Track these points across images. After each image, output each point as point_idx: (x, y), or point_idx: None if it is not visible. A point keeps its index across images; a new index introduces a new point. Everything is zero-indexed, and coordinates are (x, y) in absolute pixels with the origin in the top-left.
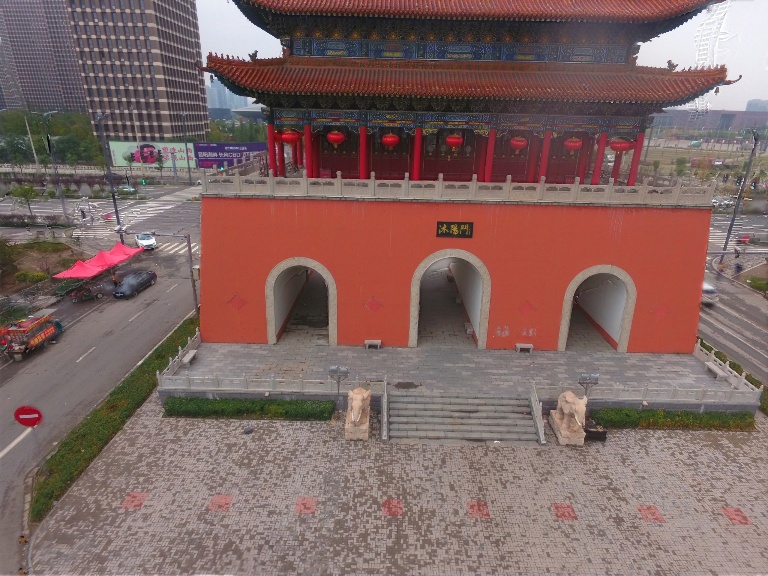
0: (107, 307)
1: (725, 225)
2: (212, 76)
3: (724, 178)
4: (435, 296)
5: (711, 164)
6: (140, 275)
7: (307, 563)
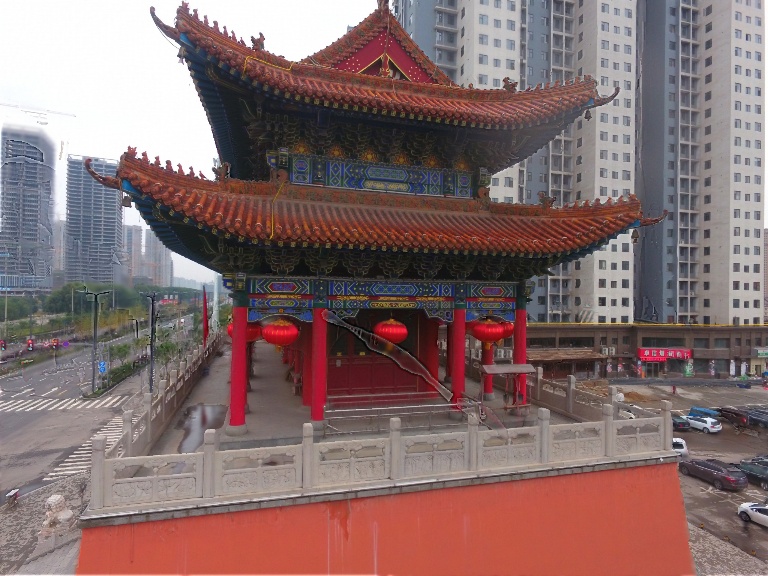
0: None
1: (5, 395)
2: (635, 233)
3: None
4: None
5: None
6: None
7: (753, 569)
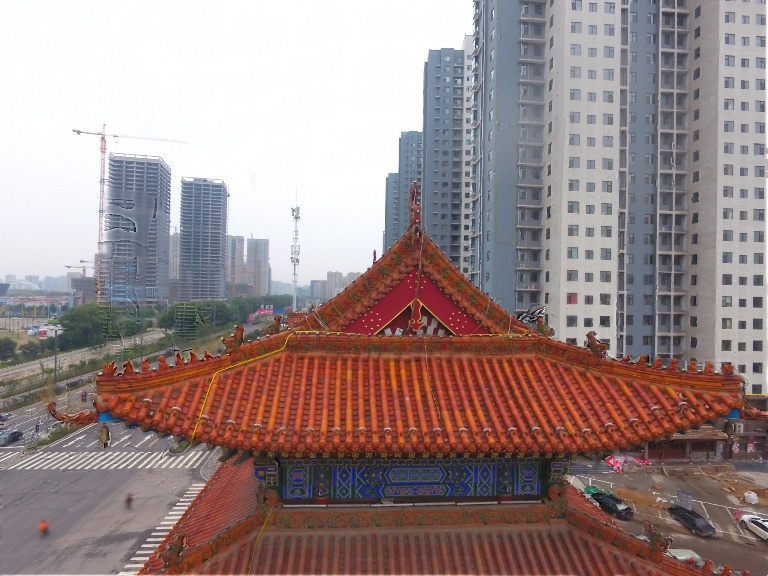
0: None
1: None
2: None
3: (83, 397)
4: None
5: (56, 385)
6: None
7: None
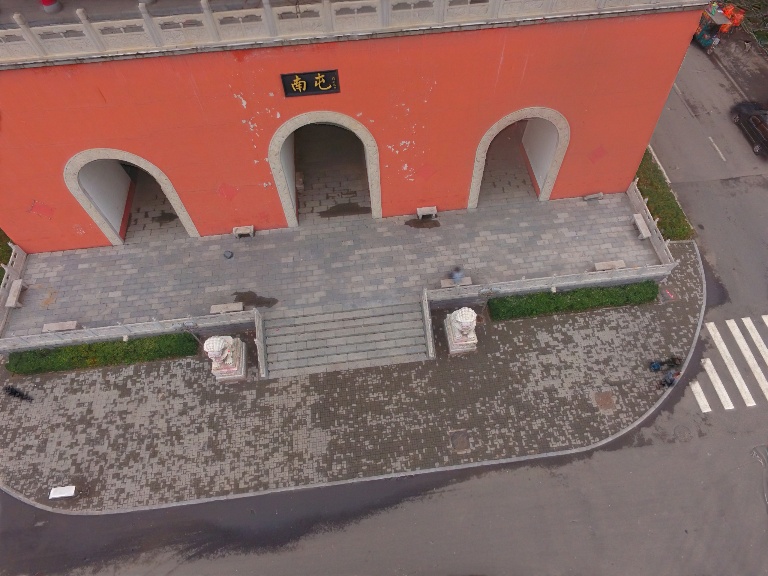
0: (730, 94)
1: None
2: None
3: None
4: (328, 126)
5: None
6: (767, 121)
7: None
